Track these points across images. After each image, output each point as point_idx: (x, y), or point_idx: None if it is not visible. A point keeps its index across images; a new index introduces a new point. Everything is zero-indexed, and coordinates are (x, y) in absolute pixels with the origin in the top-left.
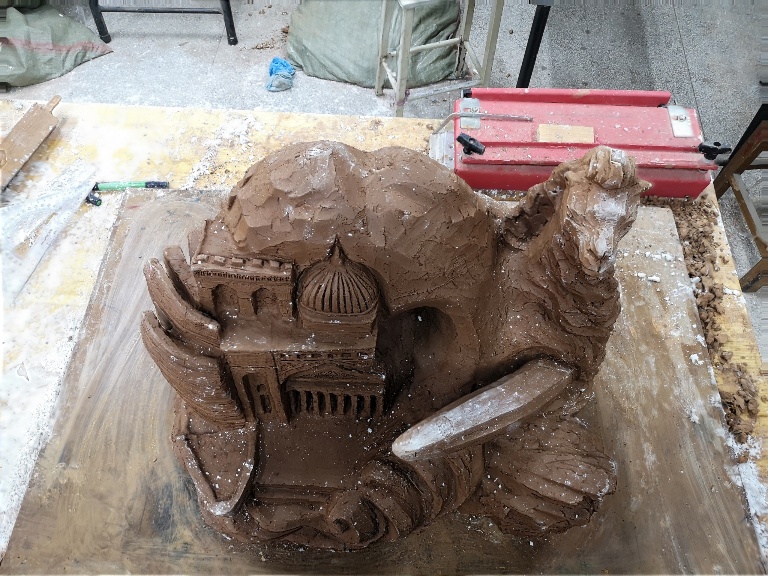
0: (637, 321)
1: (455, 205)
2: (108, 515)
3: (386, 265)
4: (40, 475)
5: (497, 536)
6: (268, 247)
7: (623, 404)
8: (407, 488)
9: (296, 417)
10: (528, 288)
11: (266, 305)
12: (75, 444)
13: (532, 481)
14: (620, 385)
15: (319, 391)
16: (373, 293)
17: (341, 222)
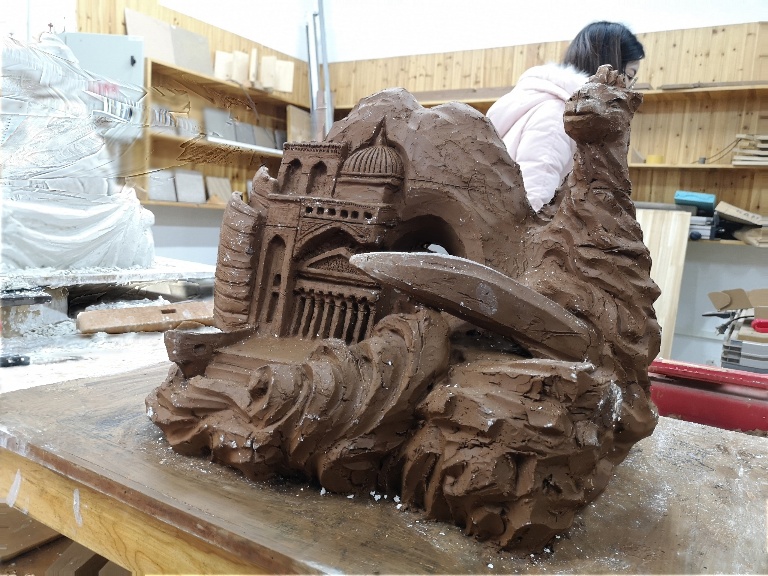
0: (760, 491)
1: (483, 133)
2: (77, 407)
3: (413, 146)
4: (62, 383)
5: (443, 543)
6: (338, 134)
7: (712, 529)
8: (350, 359)
9: (290, 338)
10: (547, 238)
11: (317, 191)
12: (105, 383)
13: (494, 368)
14: (713, 517)
15: (321, 290)
16: (396, 166)
17: (391, 109)
